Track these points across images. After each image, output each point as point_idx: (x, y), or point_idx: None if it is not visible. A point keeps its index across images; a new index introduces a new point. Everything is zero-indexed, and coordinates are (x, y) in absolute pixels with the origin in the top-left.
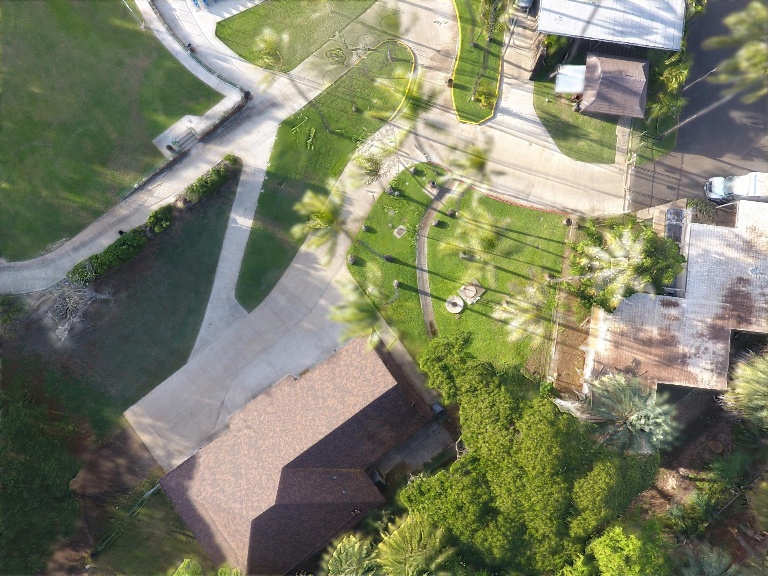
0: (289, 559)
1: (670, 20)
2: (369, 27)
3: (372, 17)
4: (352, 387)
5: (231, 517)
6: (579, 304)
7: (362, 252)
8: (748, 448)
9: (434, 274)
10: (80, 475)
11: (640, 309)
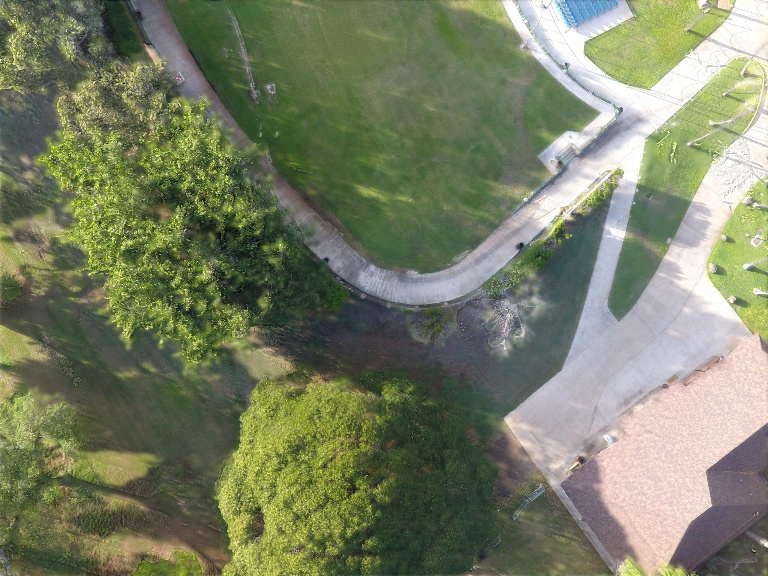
0: (695, 560)
1: None
2: (720, 44)
3: (723, 35)
4: (758, 392)
5: (660, 519)
6: None
7: (722, 261)
8: None
9: None
10: None
11: None
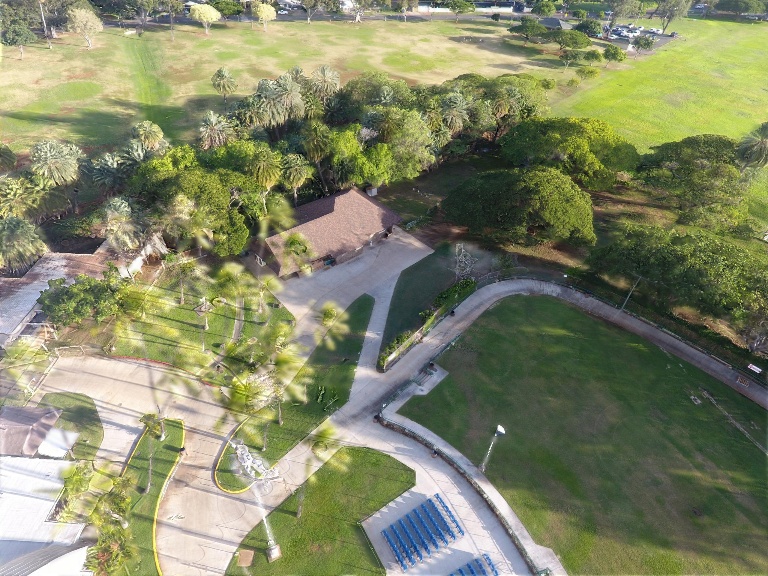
0: None
1: None
2: (258, 504)
3: (254, 516)
4: None
5: None
6: None
7: (284, 328)
8: (46, 239)
9: (231, 318)
10: (452, 231)
11: None
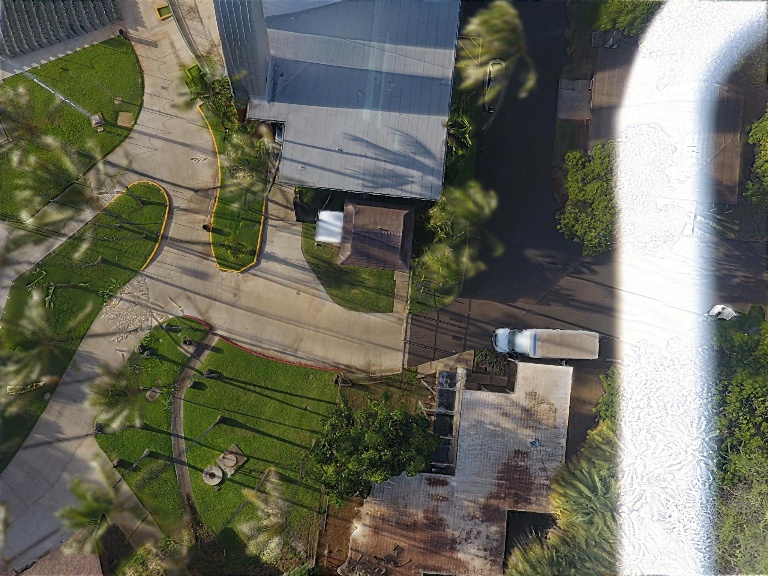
0: None
1: (428, 167)
2: (118, 167)
3: (121, 156)
4: None
5: None
6: (322, 493)
7: (110, 418)
8: None
9: (191, 441)
10: None
11: (403, 489)
